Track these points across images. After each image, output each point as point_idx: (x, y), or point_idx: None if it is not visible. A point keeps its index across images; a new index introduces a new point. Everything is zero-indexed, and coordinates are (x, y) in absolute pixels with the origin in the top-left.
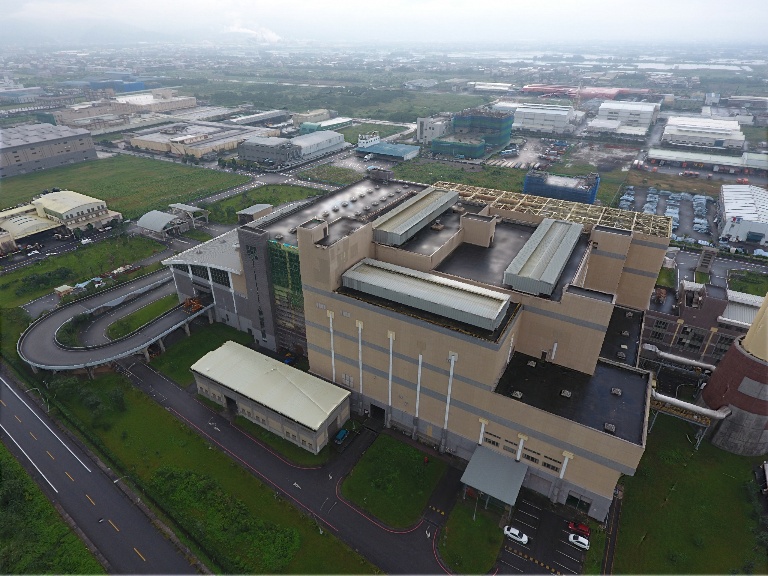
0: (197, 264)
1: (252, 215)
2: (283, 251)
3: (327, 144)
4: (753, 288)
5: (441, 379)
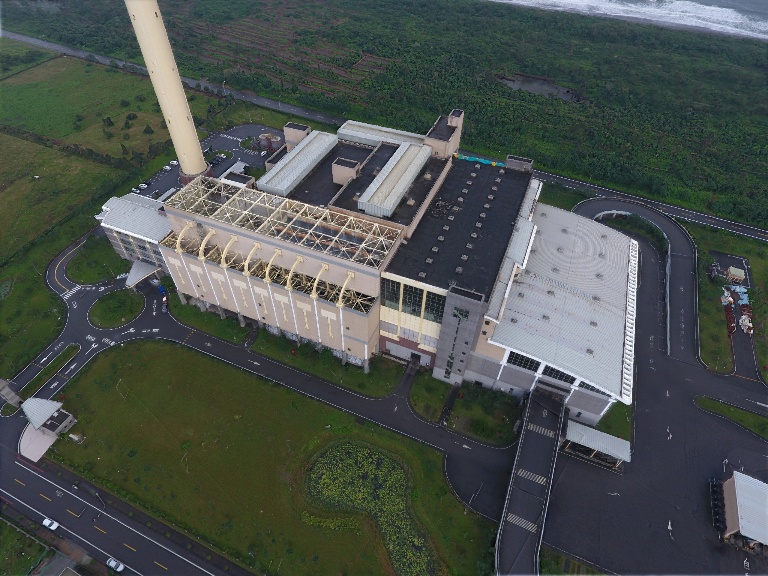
0: None
1: None
2: None
3: None
4: (3, 362)
5: None
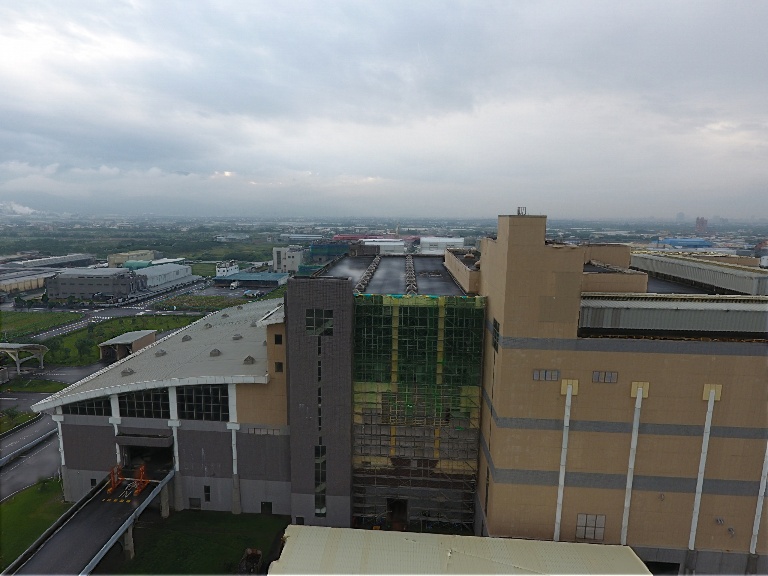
0: (145, 387)
1: (130, 344)
2: (388, 308)
3: (174, 276)
4: None
5: None
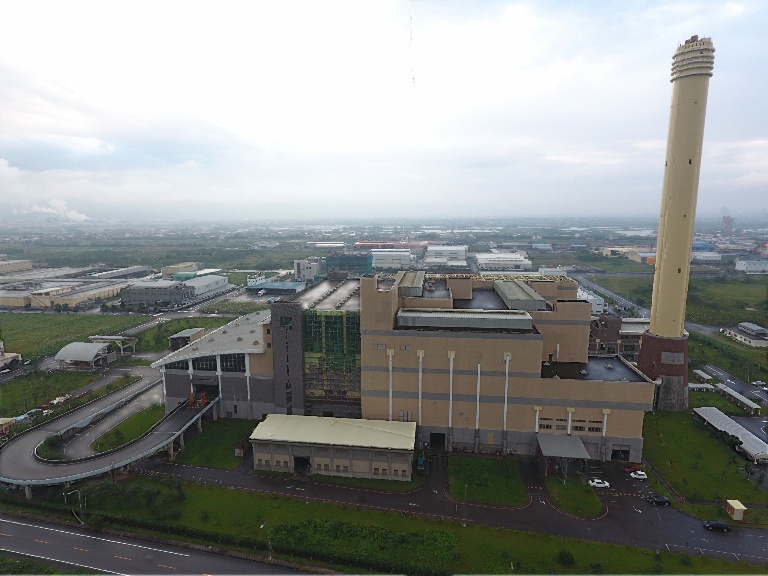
0: (205, 355)
1: (189, 337)
2: (319, 316)
3: (215, 286)
4: None
5: (498, 381)
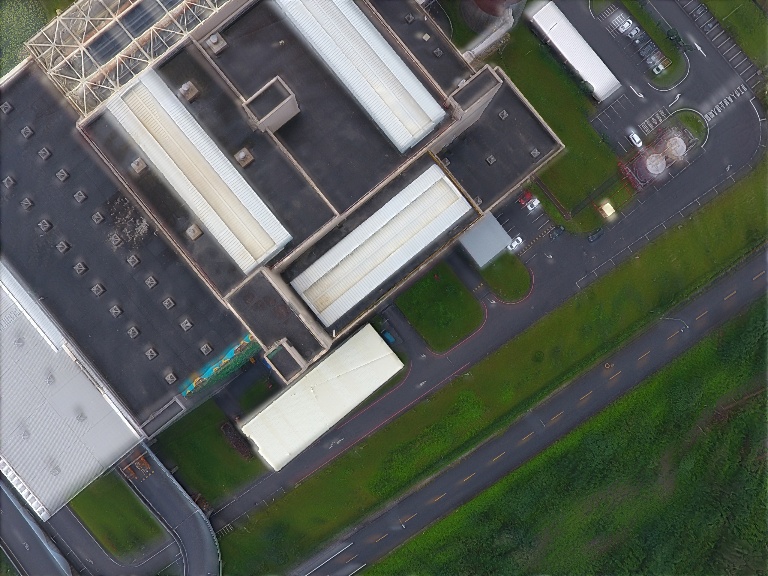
0: None
1: None
2: (209, 378)
3: None
4: None
5: None
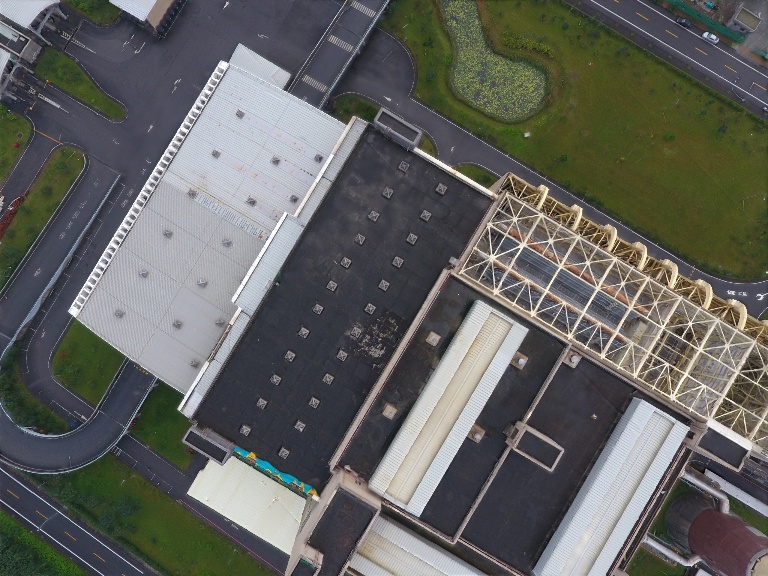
0: None
1: (144, 19)
2: None
3: None
4: None
5: None
